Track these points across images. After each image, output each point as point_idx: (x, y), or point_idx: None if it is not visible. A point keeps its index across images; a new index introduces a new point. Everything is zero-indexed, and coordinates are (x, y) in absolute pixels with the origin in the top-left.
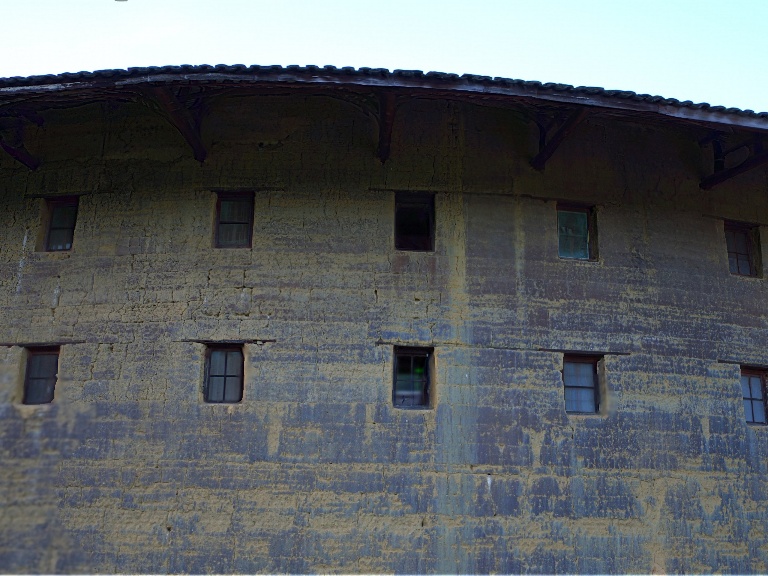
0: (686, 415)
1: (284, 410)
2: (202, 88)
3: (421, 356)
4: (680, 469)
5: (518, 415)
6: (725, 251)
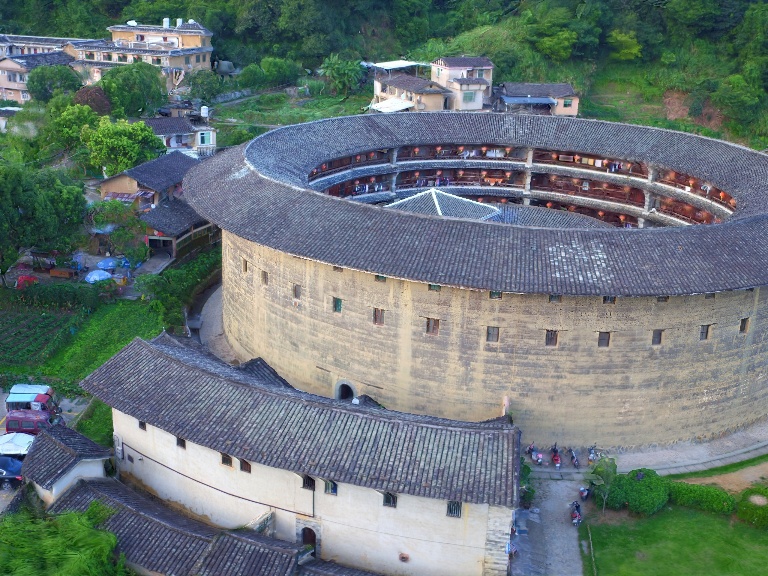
0: None
1: None
2: None
3: (744, 319)
4: None
5: None
6: None
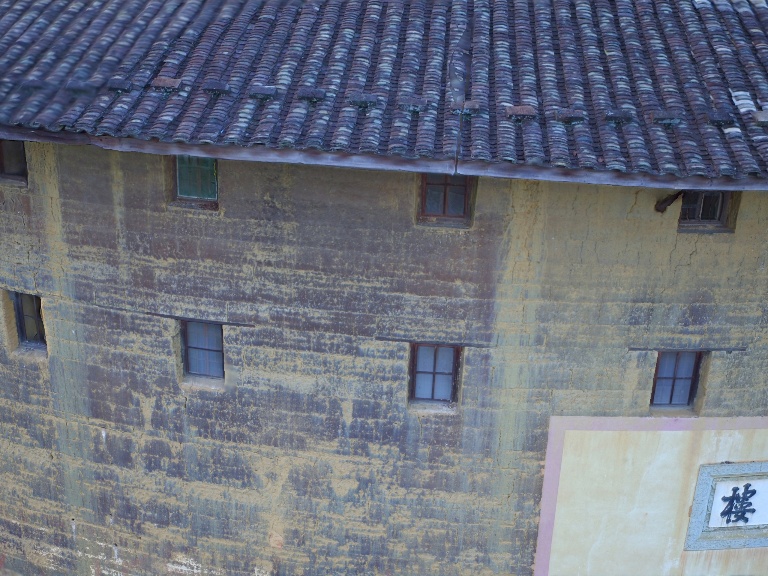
0: (322, 397)
1: None
2: None
3: None
4: (309, 450)
5: (127, 378)
6: (411, 192)
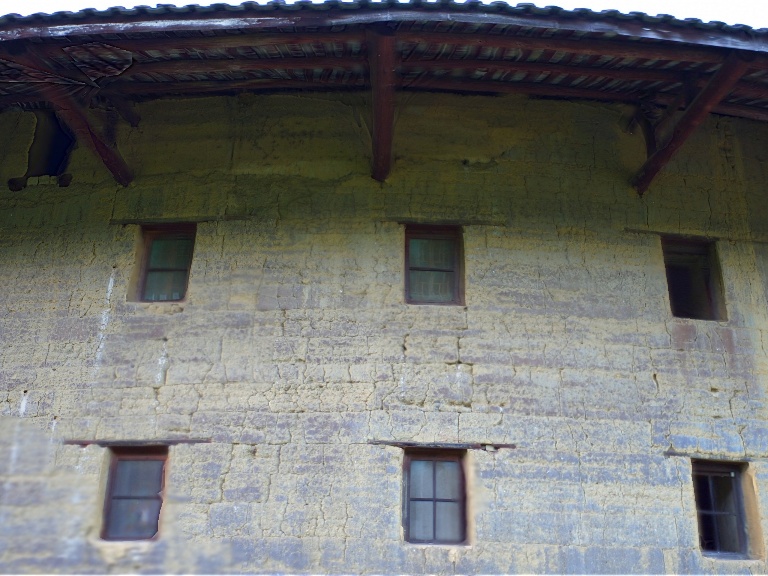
0: None
1: (538, 557)
2: (440, 52)
3: (722, 475)
4: None
5: None
6: None
